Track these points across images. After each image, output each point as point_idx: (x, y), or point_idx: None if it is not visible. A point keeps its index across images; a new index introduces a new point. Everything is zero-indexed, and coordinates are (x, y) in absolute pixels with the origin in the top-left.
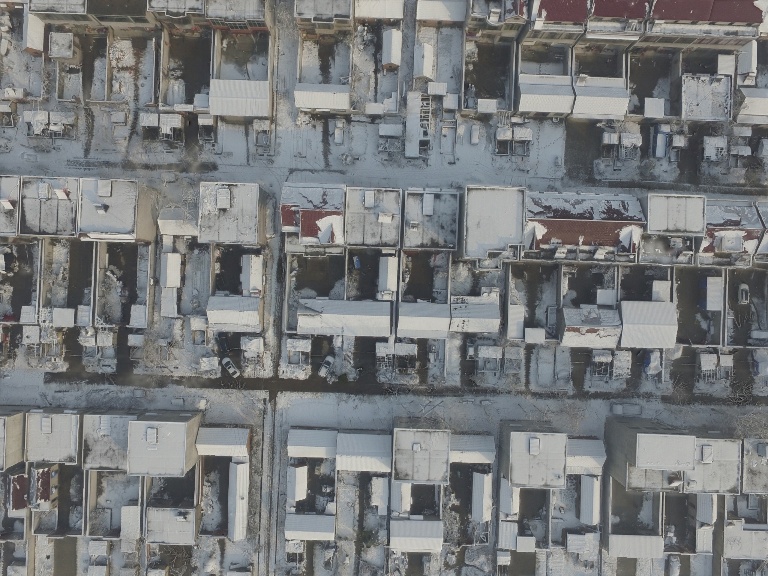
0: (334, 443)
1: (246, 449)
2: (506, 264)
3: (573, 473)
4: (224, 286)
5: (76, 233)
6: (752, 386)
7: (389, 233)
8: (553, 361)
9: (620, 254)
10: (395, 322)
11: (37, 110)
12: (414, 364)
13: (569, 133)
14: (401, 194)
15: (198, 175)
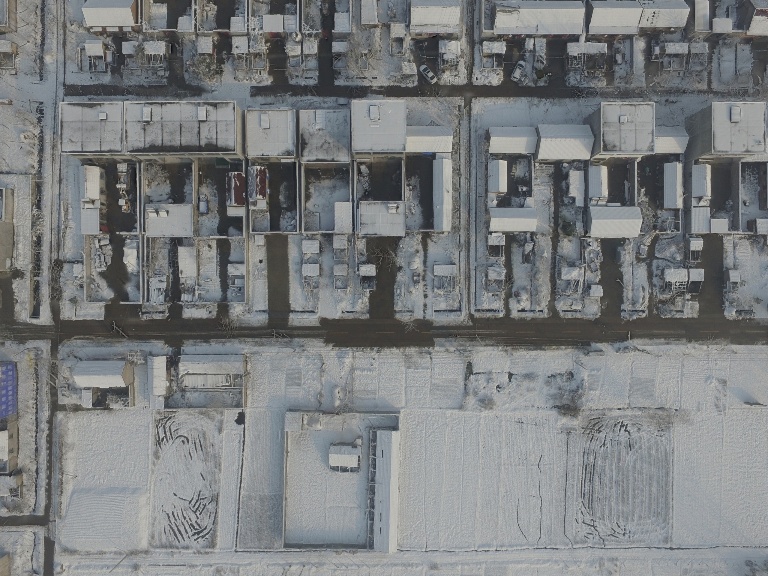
0: (534, 134)
1: (451, 142)
2: None
3: (760, 160)
4: None
5: None
6: None
7: None
8: (734, 59)
9: None
10: (585, 21)
11: None
12: (603, 64)
13: None
14: None
15: None
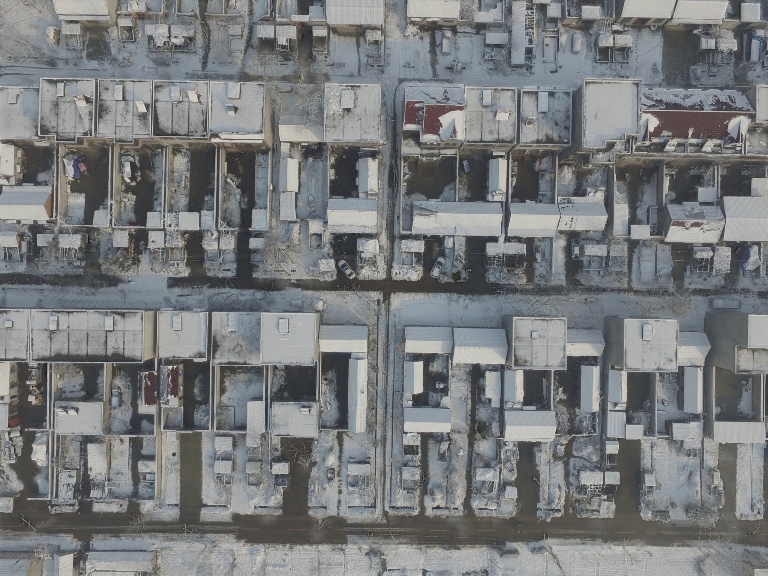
0: (450, 337)
1: (366, 344)
2: (608, 167)
3: None
4: (338, 192)
5: (207, 134)
6: None
7: (506, 130)
8: (654, 259)
9: (726, 147)
10: (505, 222)
11: (158, 24)
12: (522, 263)
13: (666, 41)
14: (517, 92)
15: (313, 85)
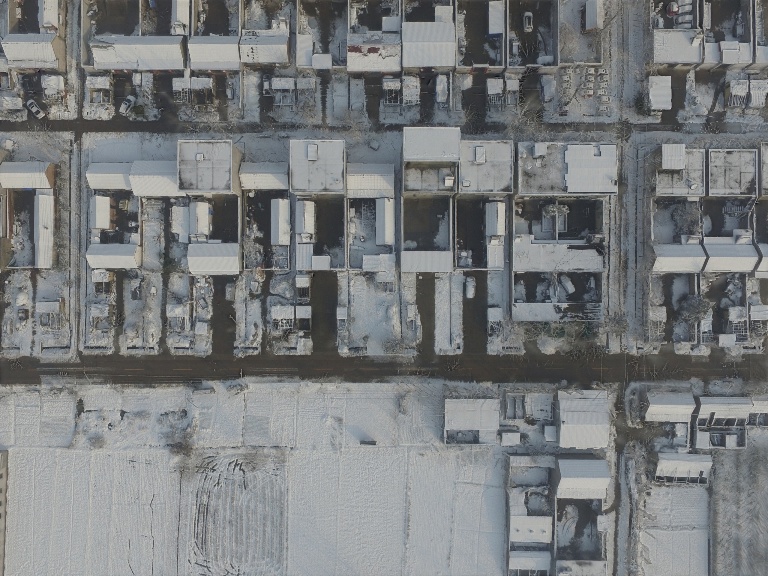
0: None
1: (46, 178)
2: None
3: (367, 196)
4: (27, 32)
5: None
6: (542, 114)
7: None
8: (348, 94)
9: None
10: (189, 56)
11: None
12: (211, 99)
13: None
14: None
15: None
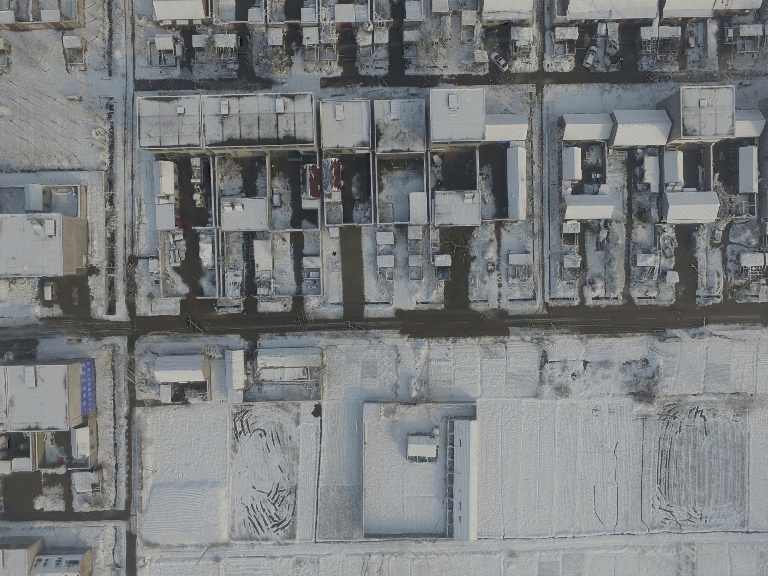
0: (609, 120)
1: (526, 130)
2: None
3: None
4: None
5: None
6: None
7: None
8: None
9: None
10: (659, 5)
11: None
12: (676, 48)
13: None
14: None
15: None
